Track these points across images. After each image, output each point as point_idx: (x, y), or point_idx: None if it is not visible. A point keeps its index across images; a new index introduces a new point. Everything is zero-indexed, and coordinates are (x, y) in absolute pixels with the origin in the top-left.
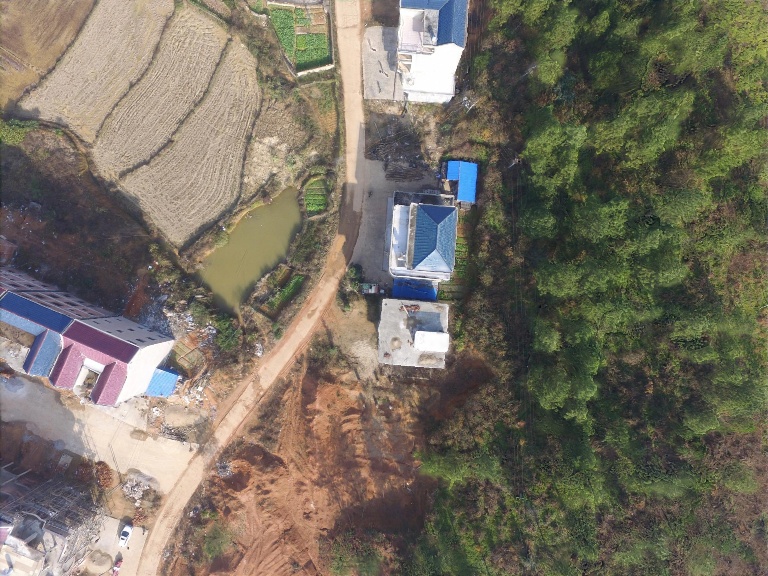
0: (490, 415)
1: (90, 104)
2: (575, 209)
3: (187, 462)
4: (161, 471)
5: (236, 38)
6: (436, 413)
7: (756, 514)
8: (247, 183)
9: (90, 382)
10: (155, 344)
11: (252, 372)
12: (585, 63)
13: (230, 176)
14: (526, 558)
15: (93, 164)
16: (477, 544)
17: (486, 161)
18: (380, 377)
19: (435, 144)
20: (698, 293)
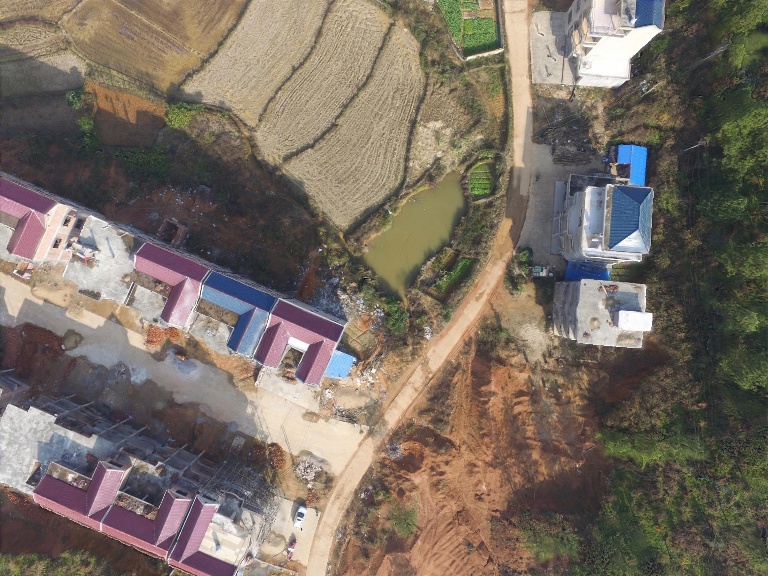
0: (668, 397)
1: (253, 88)
2: None
3: (357, 444)
4: (332, 453)
5: (400, 23)
6: (605, 395)
7: None
8: (412, 167)
9: (288, 361)
10: None
11: (421, 355)
12: (765, 47)
13: (394, 160)
14: (712, 538)
15: (257, 148)
16: (658, 524)
17: (658, 145)
18: (548, 360)
19: (603, 128)
20: None
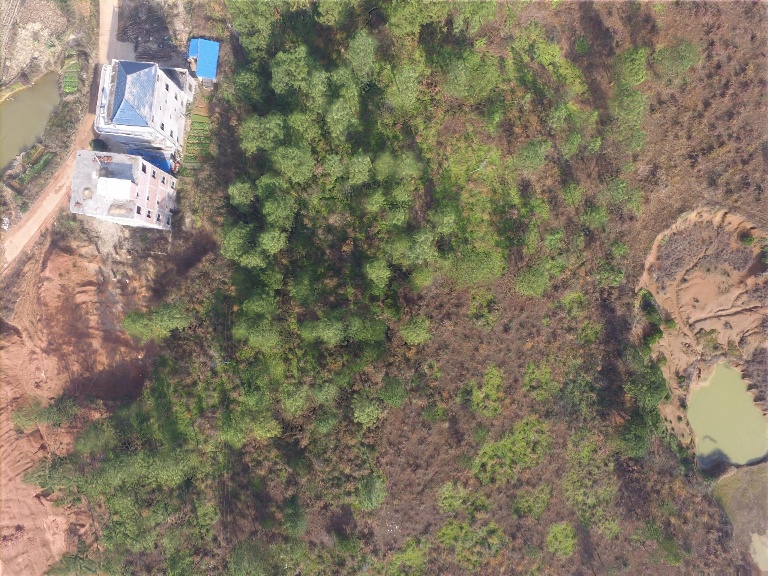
0: (209, 282)
1: None
2: (270, 65)
3: None
4: None
5: None
6: None
7: (461, 382)
8: (9, 66)
9: None
10: None
11: None
12: None
13: None
14: (226, 421)
15: None
16: (187, 410)
17: None
18: (120, 251)
19: (182, 25)
20: (402, 154)
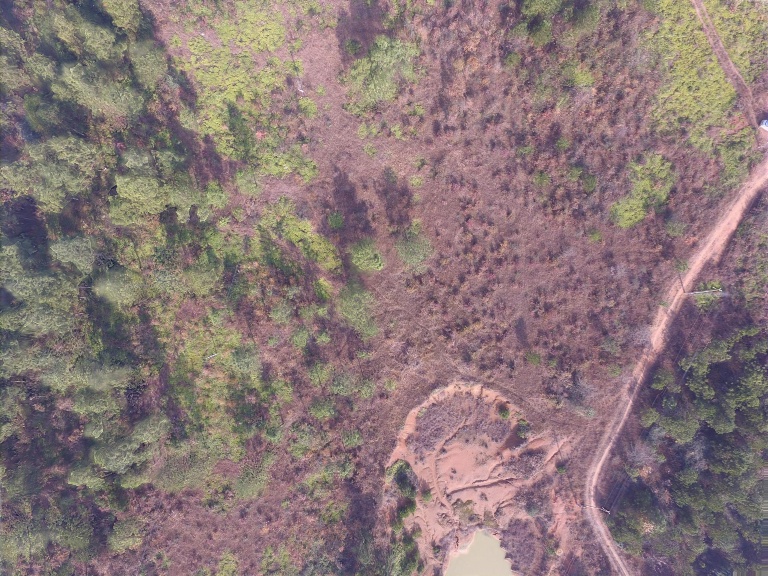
0: None
1: None
2: None
3: None
4: None
5: None
6: None
7: (191, 571)
8: None
9: None
10: None
11: None
12: None
13: None
14: None
15: None
16: None
17: None
18: None
19: None
20: (135, 340)
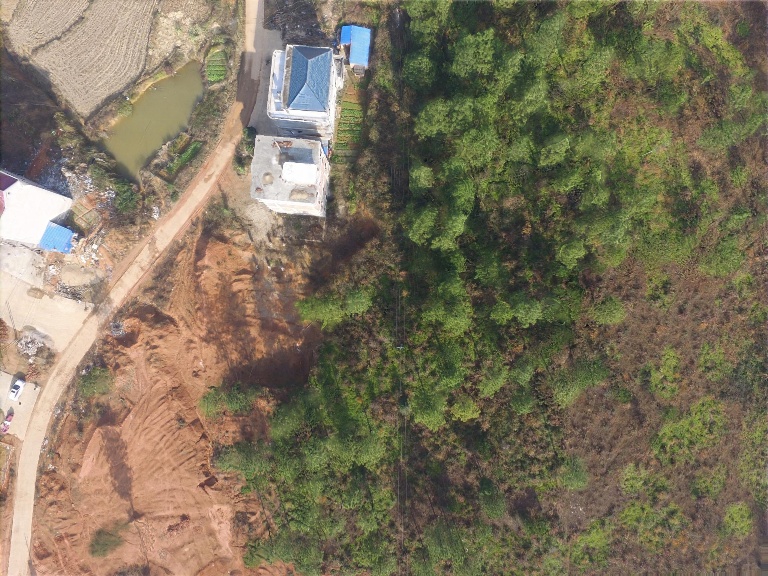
0: (374, 268)
1: None
2: (448, 48)
3: (82, 321)
4: (56, 329)
5: None
6: (327, 274)
7: (641, 363)
8: (152, 56)
9: None
10: (43, 189)
11: (148, 234)
12: None
13: (136, 50)
14: (404, 406)
15: (8, 40)
16: (358, 396)
17: (378, 25)
18: (273, 239)
19: (331, 13)
20: (577, 137)
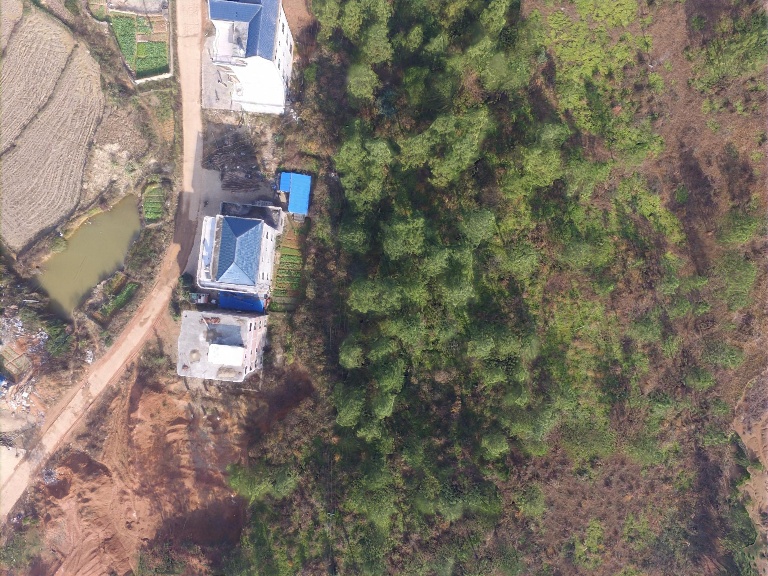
0: (308, 429)
1: None
2: (381, 225)
3: (13, 468)
4: None
5: (81, 44)
6: (263, 425)
7: (565, 538)
8: (87, 189)
9: None
10: None
11: (82, 379)
12: None
13: (71, 182)
14: (332, 575)
15: None
16: (289, 559)
17: (317, 173)
18: (209, 387)
19: (271, 155)
20: (510, 312)
